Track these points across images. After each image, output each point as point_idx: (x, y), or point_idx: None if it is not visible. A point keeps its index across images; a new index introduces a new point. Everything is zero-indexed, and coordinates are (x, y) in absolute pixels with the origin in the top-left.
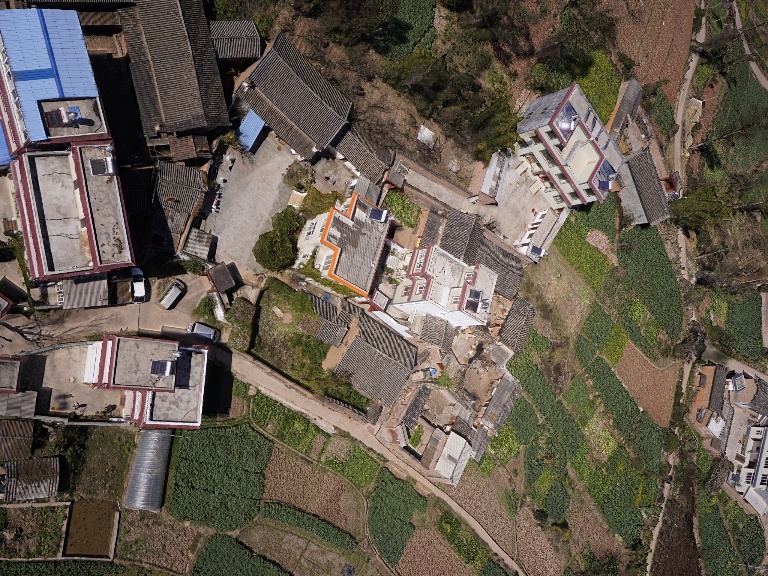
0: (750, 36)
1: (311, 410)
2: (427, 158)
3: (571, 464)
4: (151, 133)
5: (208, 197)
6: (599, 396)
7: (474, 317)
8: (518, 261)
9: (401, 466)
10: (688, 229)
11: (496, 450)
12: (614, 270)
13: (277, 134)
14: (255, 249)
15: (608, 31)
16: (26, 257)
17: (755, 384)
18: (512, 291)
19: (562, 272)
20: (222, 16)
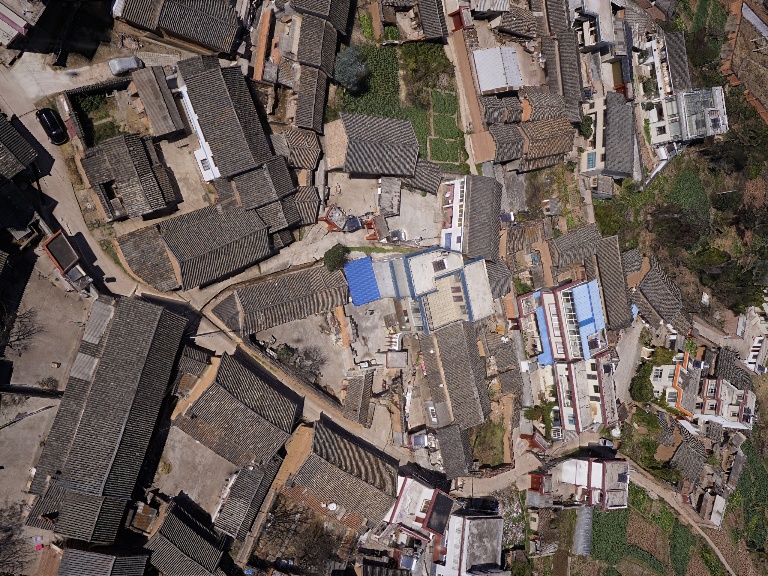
0: None
1: (648, 486)
2: (704, 313)
3: (767, 508)
4: None
5: None
6: None
7: (746, 426)
8: (748, 375)
9: (686, 517)
10: None
11: (730, 502)
12: None
13: None
14: (634, 391)
15: None
16: (552, 415)
17: None
18: None
19: (765, 376)
20: None
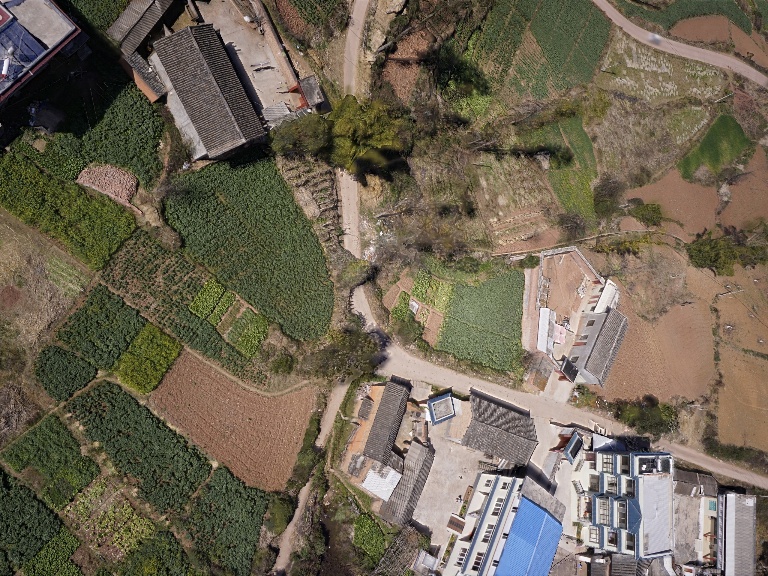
0: None
1: None
2: None
3: (25, 573)
4: None
5: None
6: (102, 449)
7: None
8: None
9: None
10: (366, 172)
11: None
12: (153, 233)
13: None
14: None
15: None
16: None
17: (471, 410)
18: None
19: (5, 236)
20: None
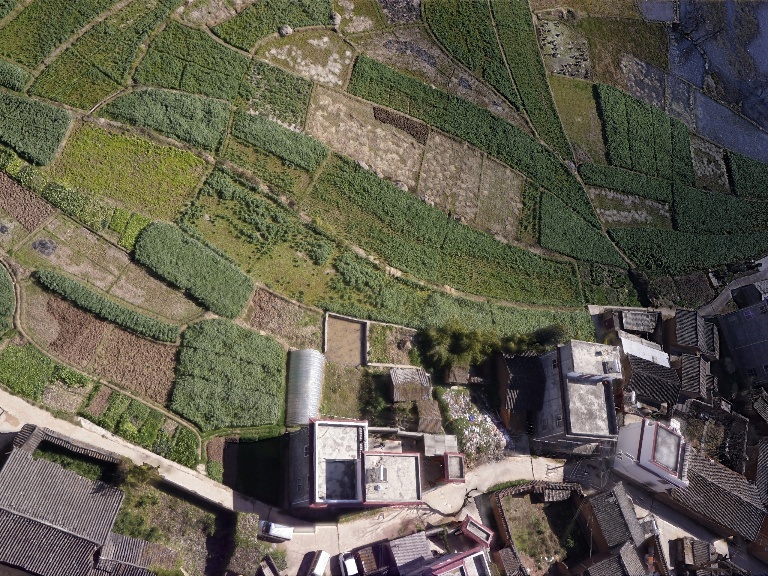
0: None
1: (119, 447)
2: None
3: None
4: None
5: None
6: None
7: None
8: None
9: None
10: None
11: None
12: None
13: None
14: None
15: None
16: None
17: None
18: None
19: None
20: None
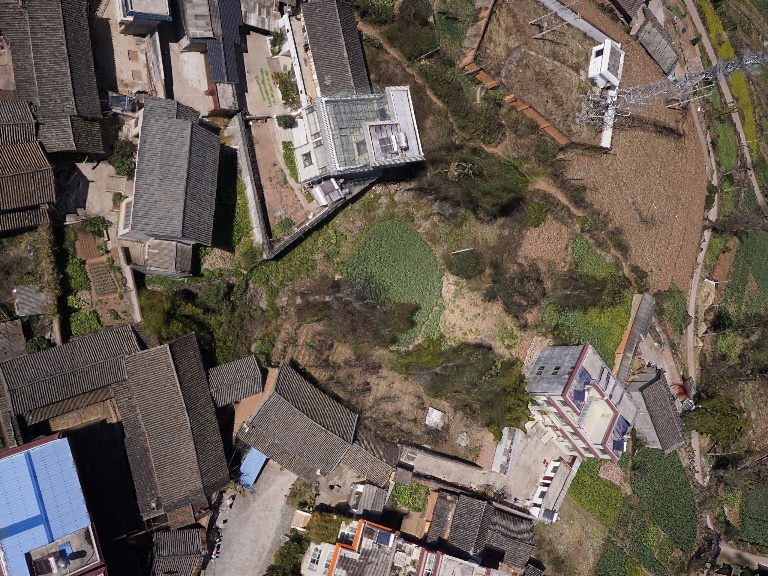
0: (761, 173)
1: None
2: (435, 438)
3: None
4: (147, 510)
5: (207, 544)
6: None
7: None
8: (529, 525)
9: None
10: None
11: None
12: (627, 499)
13: (280, 464)
14: None
15: (620, 247)
16: None
17: None
18: (523, 560)
19: (574, 517)
20: (222, 348)
